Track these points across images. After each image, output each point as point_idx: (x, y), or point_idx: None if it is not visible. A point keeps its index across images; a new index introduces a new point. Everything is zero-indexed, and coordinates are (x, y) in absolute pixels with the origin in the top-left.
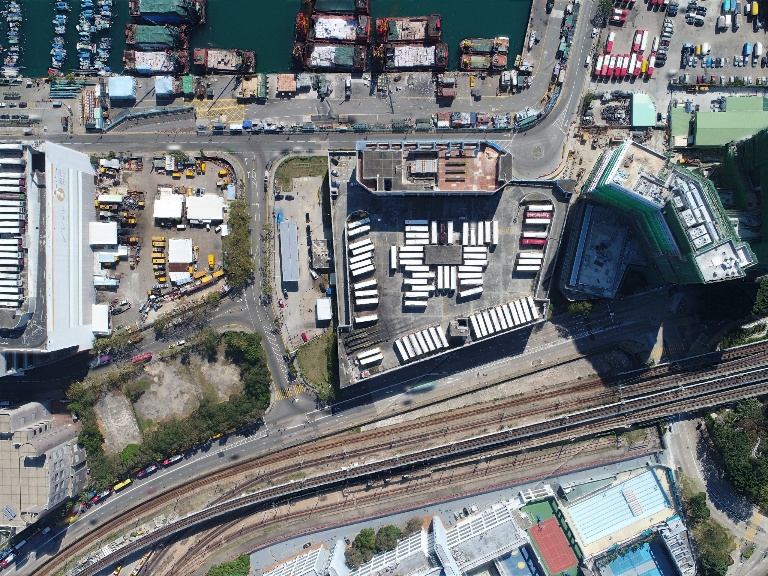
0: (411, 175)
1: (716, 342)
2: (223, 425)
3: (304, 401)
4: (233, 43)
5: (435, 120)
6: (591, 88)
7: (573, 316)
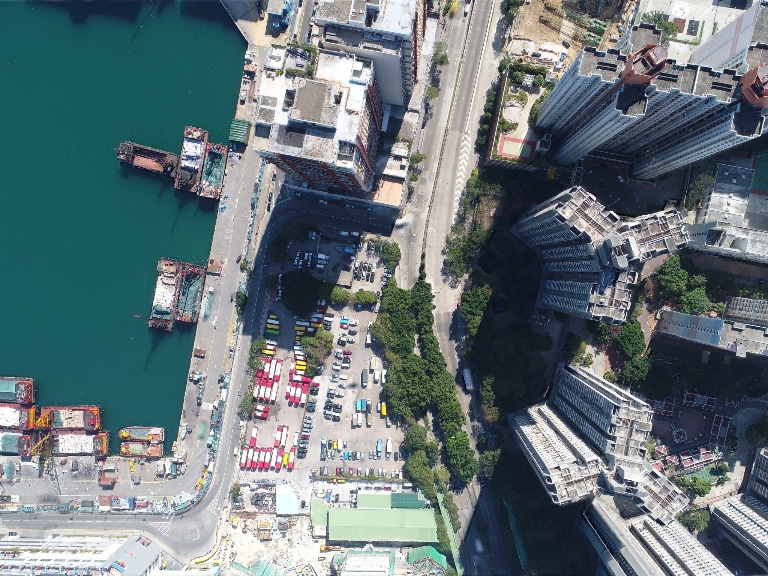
0: None
1: None
2: None
3: None
4: None
5: (97, 504)
6: (240, 476)
7: None
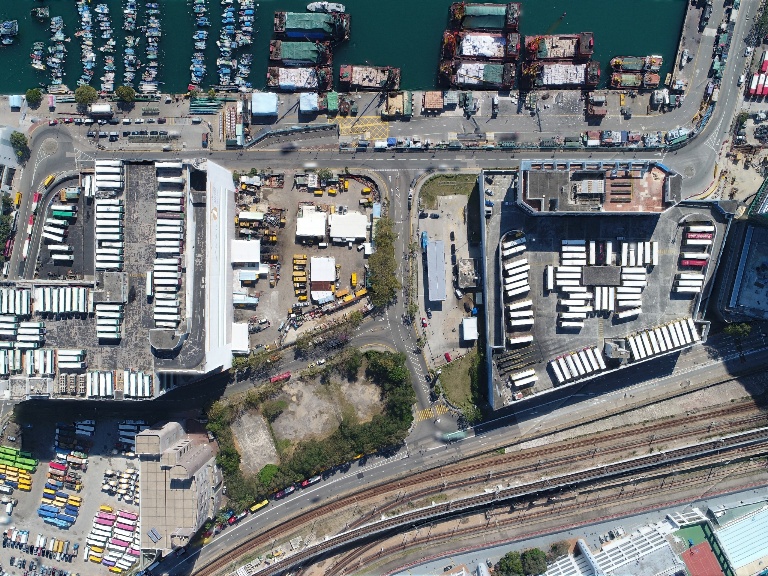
0: (575, 195)
1: None
2: (368, 446)
3: (446, 422)
4: (377, 60)
5: (585, 138)
6: (744, 107)
7: (723, 337)
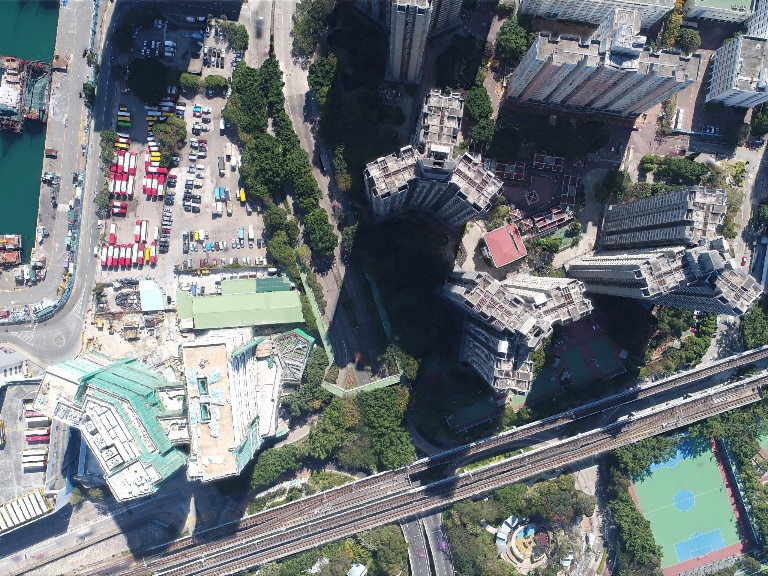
0: None
1: (244, 507)
2: None
3: None
4: None
5: None
6: (103, 276)
7: None
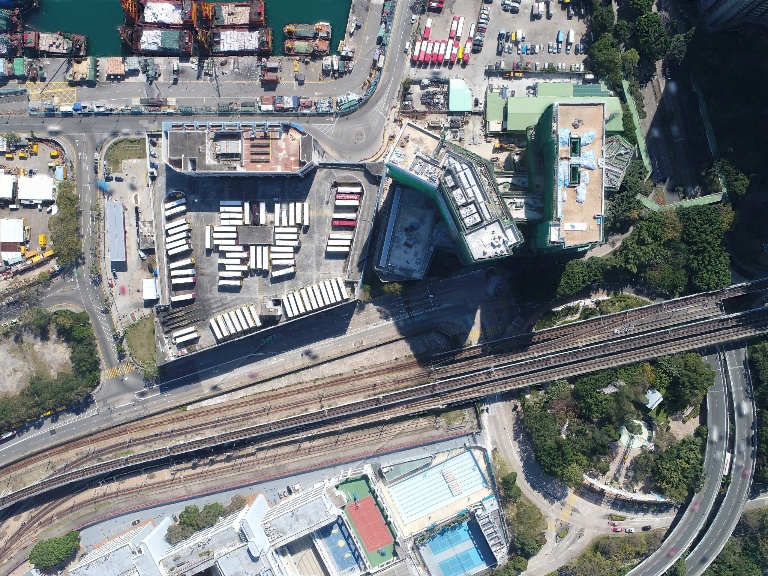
0: (217, 156)
1: (532, 325)
2: (49, 402)
3: (133, 380)
4: (66, 27)
5: (259, 104)
6: (411, 73)
7: (394, 298)
